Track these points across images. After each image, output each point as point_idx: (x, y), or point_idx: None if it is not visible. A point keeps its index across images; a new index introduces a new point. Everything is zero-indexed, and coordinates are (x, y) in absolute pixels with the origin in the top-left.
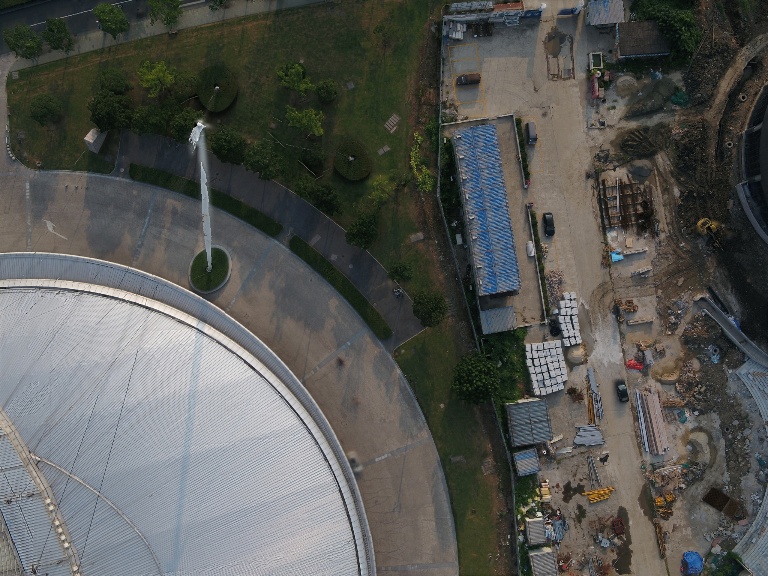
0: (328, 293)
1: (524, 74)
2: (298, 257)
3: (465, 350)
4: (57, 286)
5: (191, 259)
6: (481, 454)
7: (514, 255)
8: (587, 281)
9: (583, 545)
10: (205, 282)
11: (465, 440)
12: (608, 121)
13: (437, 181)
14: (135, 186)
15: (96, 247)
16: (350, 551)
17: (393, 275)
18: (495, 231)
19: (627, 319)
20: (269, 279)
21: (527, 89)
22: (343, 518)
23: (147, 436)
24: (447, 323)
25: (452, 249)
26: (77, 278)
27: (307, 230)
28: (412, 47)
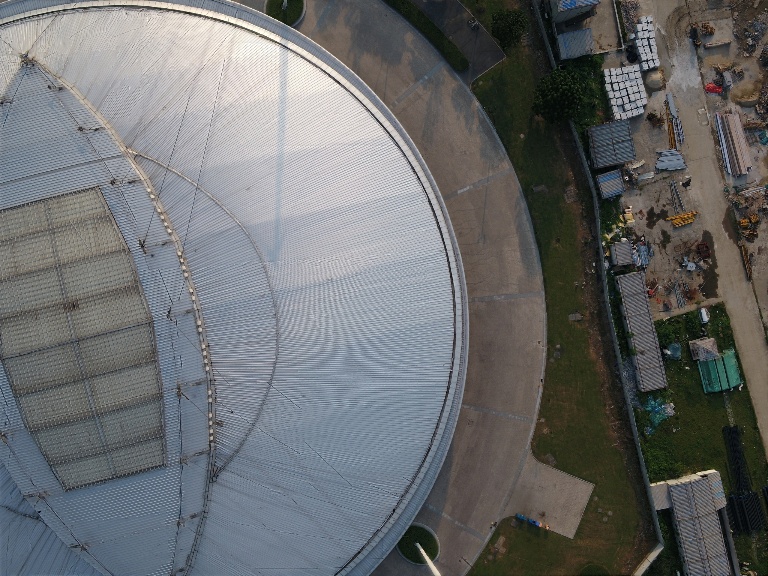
0: (403, 28)
1: None
2: None
3: None
4: (140, 4)
5: None
6: (563, 182)
7: None
8: (662, 6)
9: (669, 270)
10: (281, 18)
11: (546, 169)
12: None
13: None
14: None
15: None
16: (442, 261)
17: None
18: None
19: (704, 43)
20: (344, 16)
21: None
22: (434, 228)
23: (240, 135)
24: (524, 52)
25: None
26: None
27: None
28: None
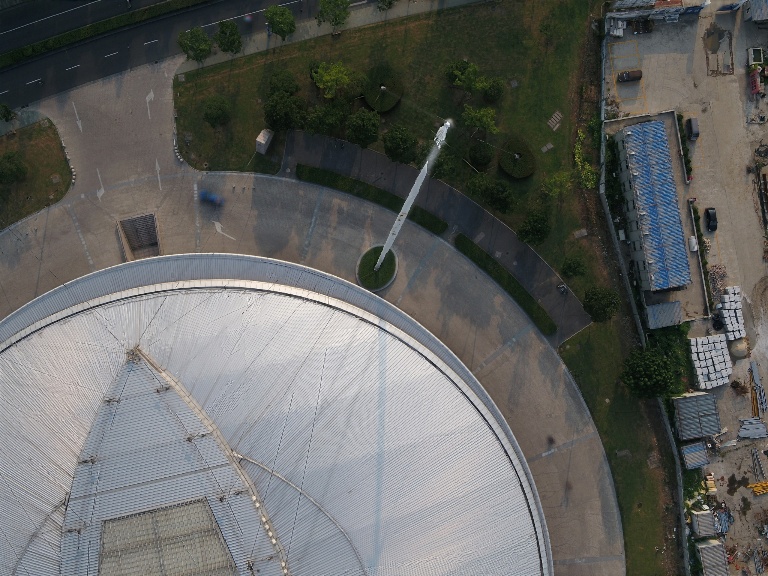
0: (493, 290)
1: (684, 70)
2: (463, 255)
3: (629, 345)
4: (242, 286)
5: (358, 258)
6: (646, 448)
7: (684, 250)
8: (749, 275)
9: (748, 537)
10: (373, 280)
11: (631, 434)
12: (767, 116)
13: (600, 178)
14: (301, 186)
15: (264, 247)
16: (532, 545)
17: (566, 271)
18: (666, 226)
19: None
20: (435, 277)
21: (687, 85)
22: (525, 512)
23: (342, 433)
24: (611, 318)
25: (617, 245)
26: (254, 278)
27: (471, 228)
28: (573, 45)
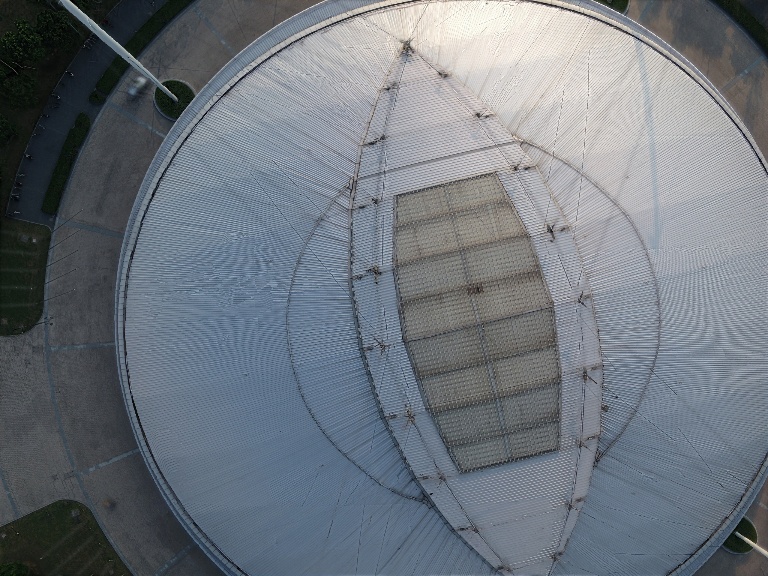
0: (724, 23)
1: None
2: None
3: None
4: None
5: None
6: None
7: None
8: None
9: None
10: None
11: None
12: None
13: None
14: None
15: None
16: None
17: None
18: None
19: None
20: (666, 10)
21: None
22: None
23: (614, 124)
24: None
25: None
26: None
27: None
28: None
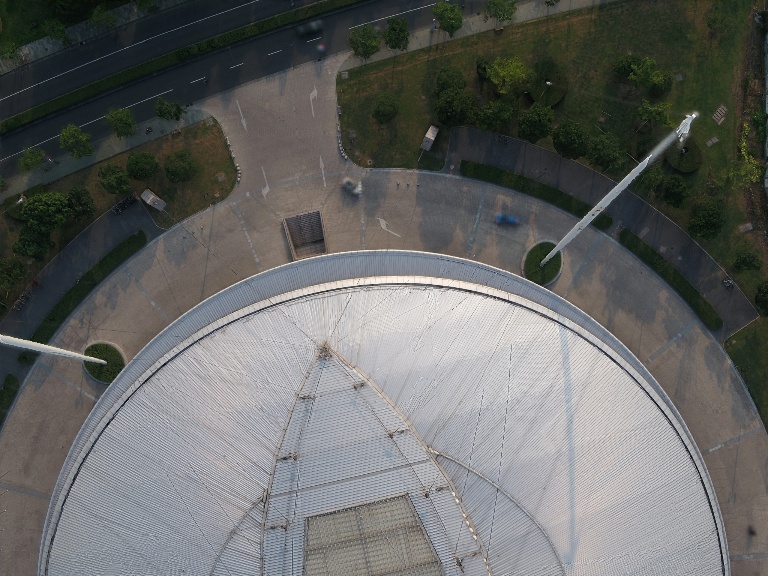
0: (658, 285)
1: None
2: (627, 250)
3: None
4: (423, 282)
5: (523, 254)
6: None
7: None
8: None
9: None
10: (540, 276)
11: None
12: None
13: (765, 171)
14: (465, 182)
15: (429, 244)
16: (714, 541)
17: (741, 266)
18: None
19: None
20: (600, 272)
21: None
22: (707, 508)
23: (533, 429)
24: None
25: None
26: (428, 274)
27: (636, 223)
28: (737, 38)
